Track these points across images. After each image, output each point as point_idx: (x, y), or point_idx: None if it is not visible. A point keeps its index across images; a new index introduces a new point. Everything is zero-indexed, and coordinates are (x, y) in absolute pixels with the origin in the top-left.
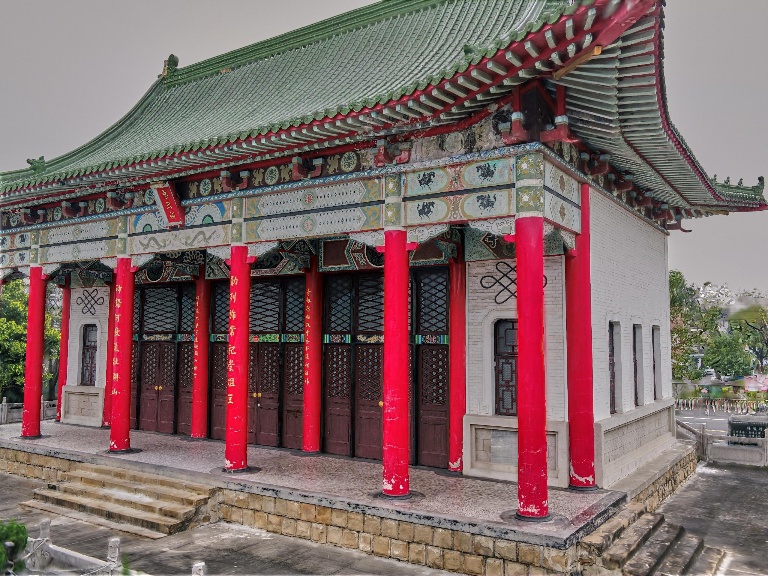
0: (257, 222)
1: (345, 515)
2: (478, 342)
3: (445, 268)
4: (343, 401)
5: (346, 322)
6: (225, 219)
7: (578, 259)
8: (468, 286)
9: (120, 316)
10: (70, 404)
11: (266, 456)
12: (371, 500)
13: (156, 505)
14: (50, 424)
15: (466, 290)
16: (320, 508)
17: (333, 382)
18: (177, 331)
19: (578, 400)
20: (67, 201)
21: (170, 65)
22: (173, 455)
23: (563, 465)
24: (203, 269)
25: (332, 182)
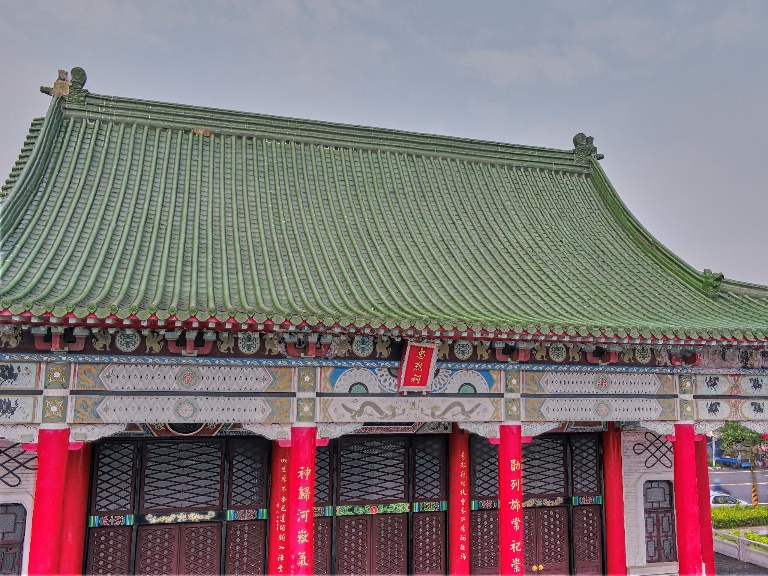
0: (540, 400)
1: None
2: (633, 501)
3: (597, 434)
4: (491, 571)
5: (495, 486)
6: (495, 391)
7: None
8: (623, 452)
9: (309, 512)
10: None
11: None
12: None
13: None
14: None
15: (622, 456)
16: None
17: (479, 552)
18: (226, 506)
19: (711, 544)
20: None
21: (78, 84)
22: None
23: None
24: None
25: None
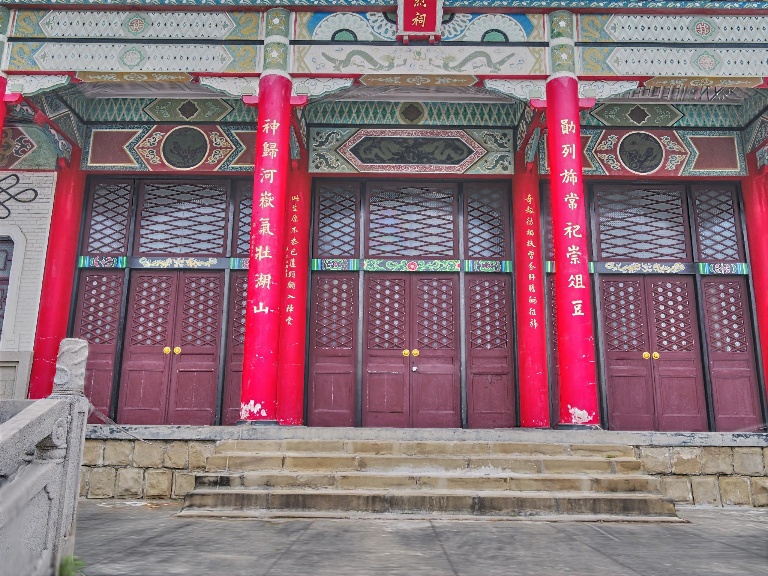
0: (605, 49)
1: None
2: None
3: (732, 184)
4: None
5: None
6: (535, 39)
7: None
8: None
9: (276, 173)
10: None
11: None
12: None
13: (571, 477)
14: None
15: None
16: None
17: None
18: (230, 253)
19: None
20: None
21: None
22: None
23: None
24: (305, 156)
25: (754, 9)
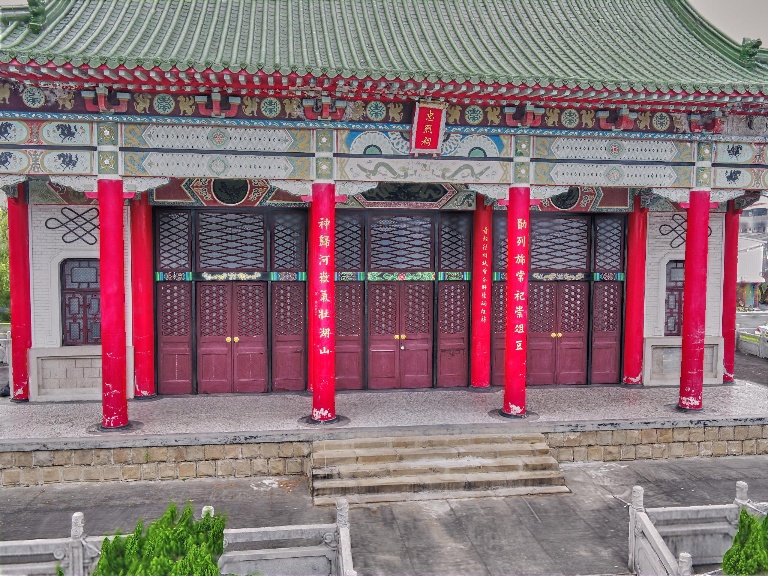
0: (550, 164)
1: (687, 431)
2: (655, 279)
3: (623, 215)
4: None
5: None
6: (504, 155)
7: (737, 217)
8: (649, 232)
9: (329, 257)
10: (45, 374)
11: (467, 398)
12: (695, 415)
13: (513, 463)
14: (32, 407)
15: (647, 236)
16: (662, 430)
17: (500, 318)
18: (270, 268)
19: (732, 320)
20: (220, 93)
21: None
22: (393, 413)
23: (721, 368)
24: None
25: (649, 138)
